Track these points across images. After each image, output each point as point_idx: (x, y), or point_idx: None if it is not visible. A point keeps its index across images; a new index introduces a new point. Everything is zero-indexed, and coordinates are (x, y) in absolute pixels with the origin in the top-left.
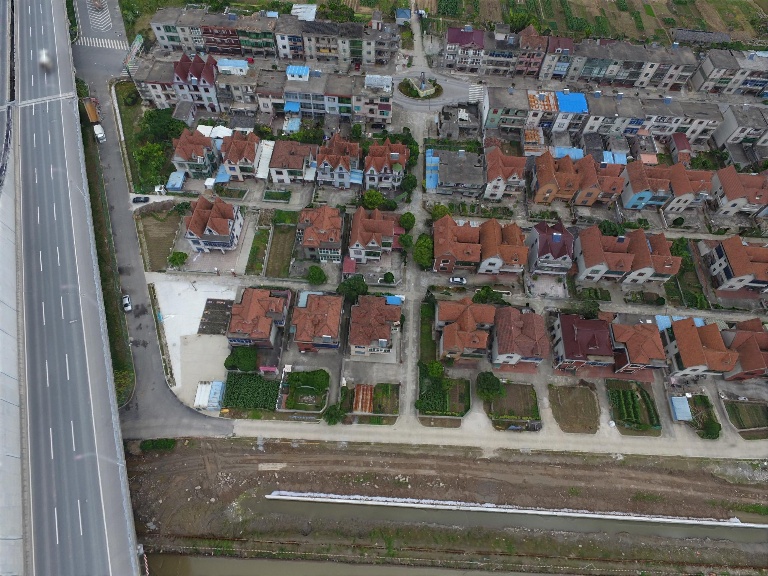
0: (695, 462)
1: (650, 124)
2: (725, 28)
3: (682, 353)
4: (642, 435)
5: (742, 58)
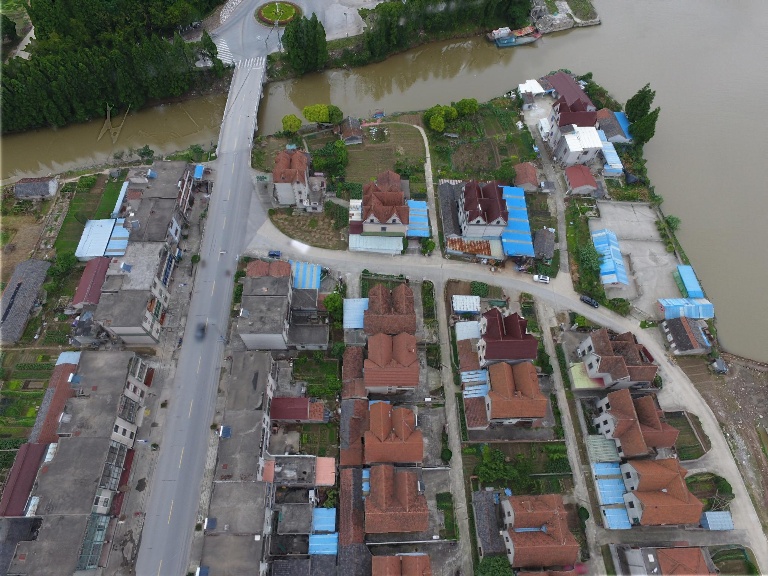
0: (762, 513)
1: (262, 462)
2: (4, 255)
3: (683, 522)
4: (761, 574)
5: (125, 280)
